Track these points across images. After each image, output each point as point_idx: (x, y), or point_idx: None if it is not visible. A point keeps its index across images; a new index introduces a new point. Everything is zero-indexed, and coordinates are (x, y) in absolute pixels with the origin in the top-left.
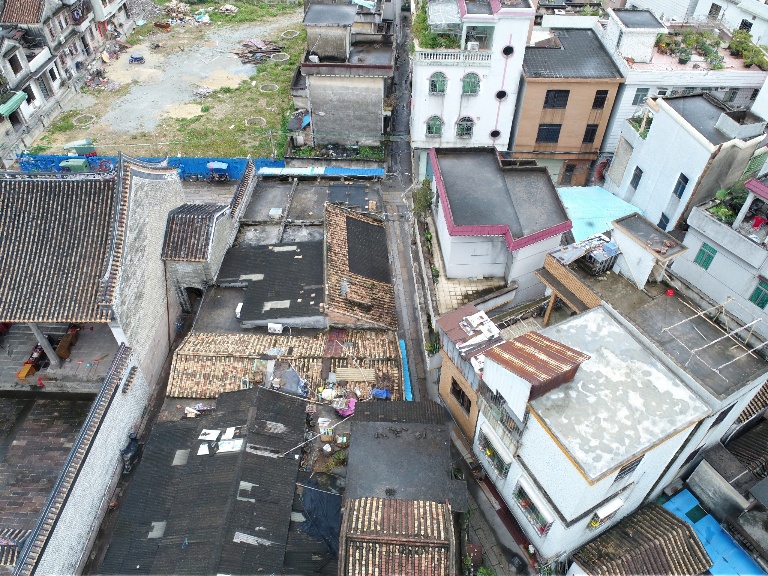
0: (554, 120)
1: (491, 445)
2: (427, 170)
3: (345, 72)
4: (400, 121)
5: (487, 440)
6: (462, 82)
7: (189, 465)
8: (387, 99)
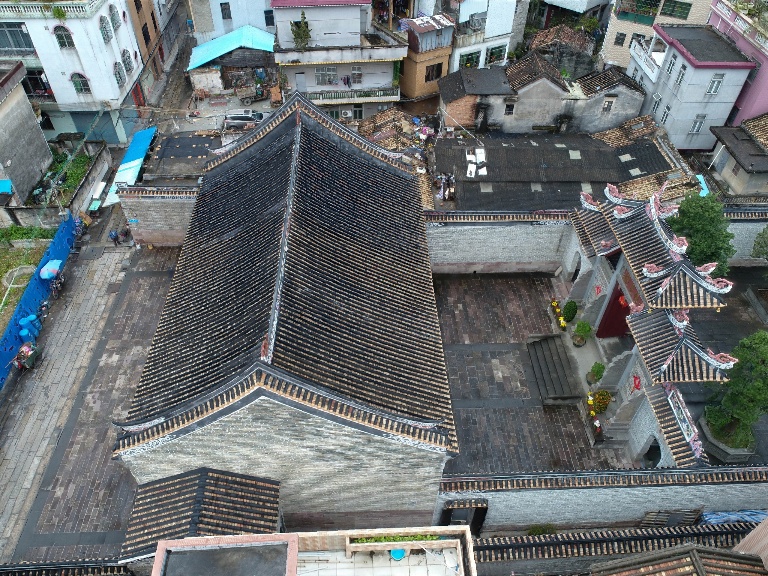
0: (143, 21)
1: (470, 56)
2: (123, 128)
3: (2, 95)
4: (56, 116)
5: (467, 57)
6: (110, 18)
7: (494, 178)
8: (32, 103)
